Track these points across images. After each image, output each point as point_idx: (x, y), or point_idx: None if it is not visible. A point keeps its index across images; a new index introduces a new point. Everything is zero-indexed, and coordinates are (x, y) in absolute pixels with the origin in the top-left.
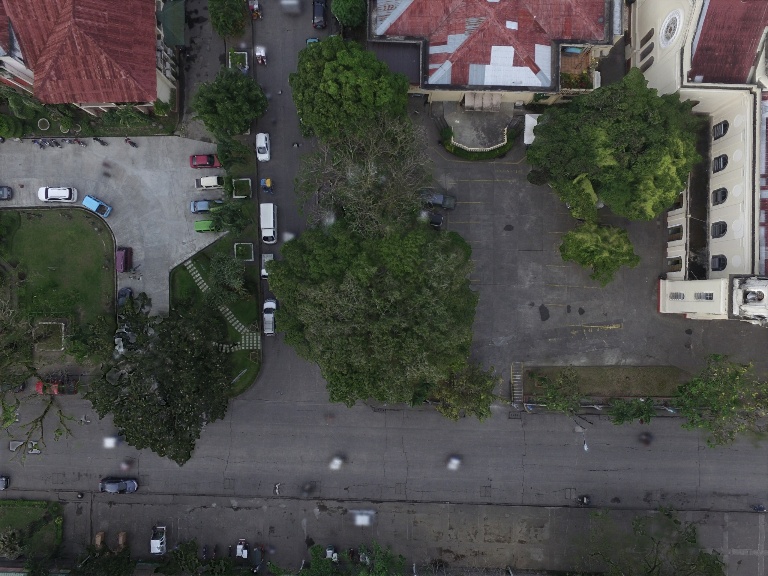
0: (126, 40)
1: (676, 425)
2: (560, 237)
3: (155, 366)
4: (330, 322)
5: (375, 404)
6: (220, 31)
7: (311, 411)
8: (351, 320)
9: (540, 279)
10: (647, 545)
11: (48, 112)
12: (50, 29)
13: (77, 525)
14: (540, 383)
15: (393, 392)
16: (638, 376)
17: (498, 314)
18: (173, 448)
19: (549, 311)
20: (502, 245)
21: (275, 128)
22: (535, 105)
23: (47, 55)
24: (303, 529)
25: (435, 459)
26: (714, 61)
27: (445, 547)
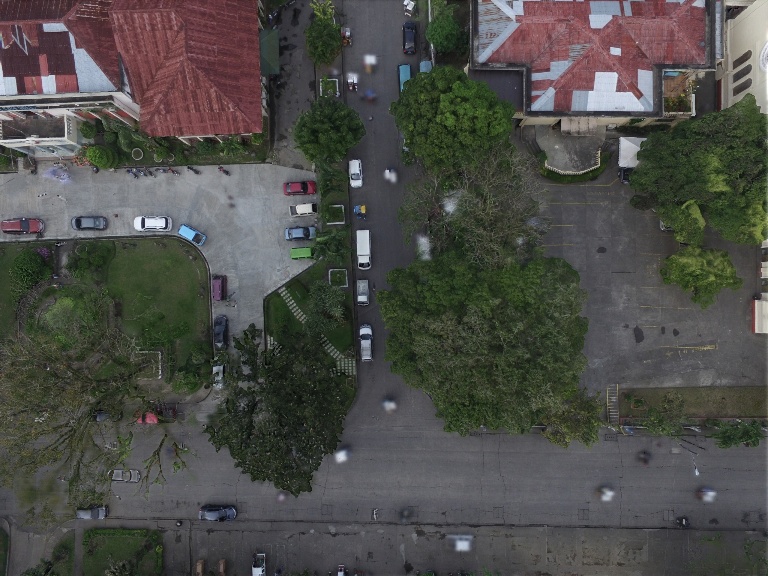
0: (234, 73)
1: None
2: (655, 259)
3: (279, 400)
4: (450, 353)
5: None
6: (317, 60)
7: (407, 436)
8: (475, 352)
9: (634, 301)
10: (746, 566)
11: (144, 142)
12: (159, 63)
13: (176, 553)
14: (637, 405)
15: (515, 422)
16: (734, 397)
17: (593, 336)
18: (297, 481)
19: (643, 333)
20: (595, 267)
21: (366, 154)
22: (627, 127)
23: (156, 89)
24: (401, 554)
25: (532, 482)
26: None
27: (544, 570)
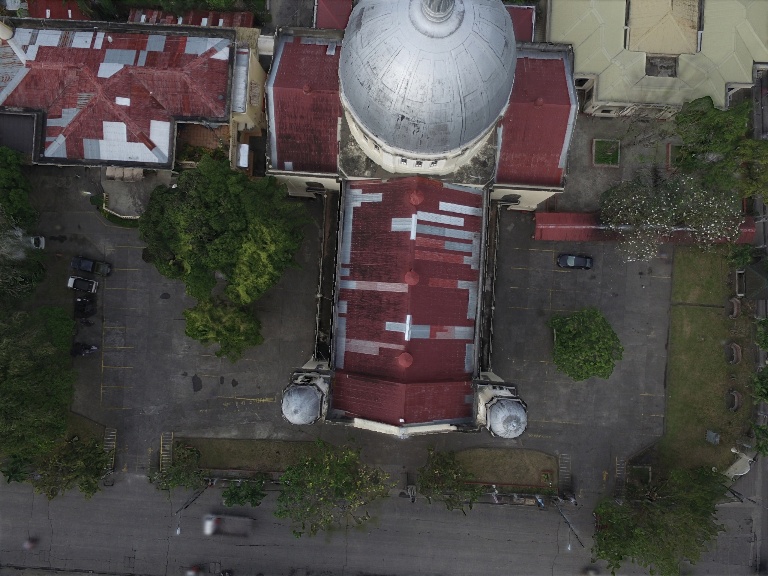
0: None
1: None
2: None
3: None
4: None
5: None
6: None
7: None
8: None
9: (194, 349)
10: None
11: None
12: None
13: None
14: None
15: None
16: (289, 451)
17: (150, 383)
18: None
19: (202, 382)
20: (158, 313)
21: None
22: None
23: None
24: None
25: (80, 527)
26: (298, 149)
27: None
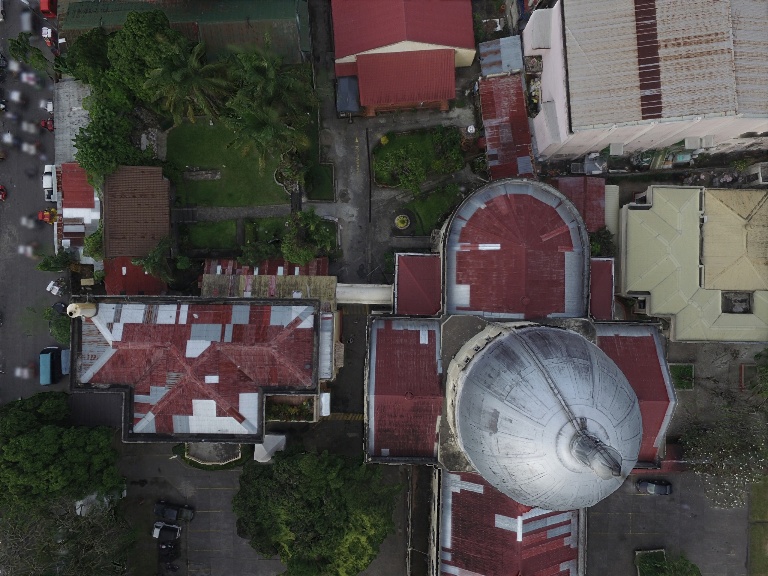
0: None
1: None
2: None
3: None
4: None
5: None
6: None
7: None
8: None
9: None
10: None
11: None
12: None
13: None
14: None
15: None
16: None
17: None
18: None
19: None
20: (242, 554)
21: None
22: None
23: None
24: None
25: None
26: (396, 439)
27: None
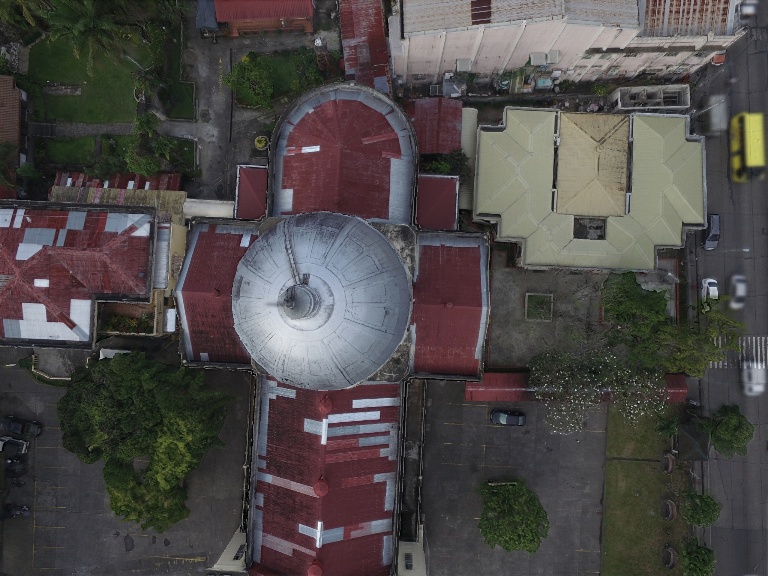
0: None
1: None
2: None
3: None
4: None
5: None
6: None
7: None
8: None
9: None
10: None
11: None
12: None
13: None
14: None
15: None
16: None
17: (82, 543)
18: None
19: (134, 541)
20: (89, 472)
21: None
22: None
23: None
24: None
25: None
26: (212, 342)
27: None
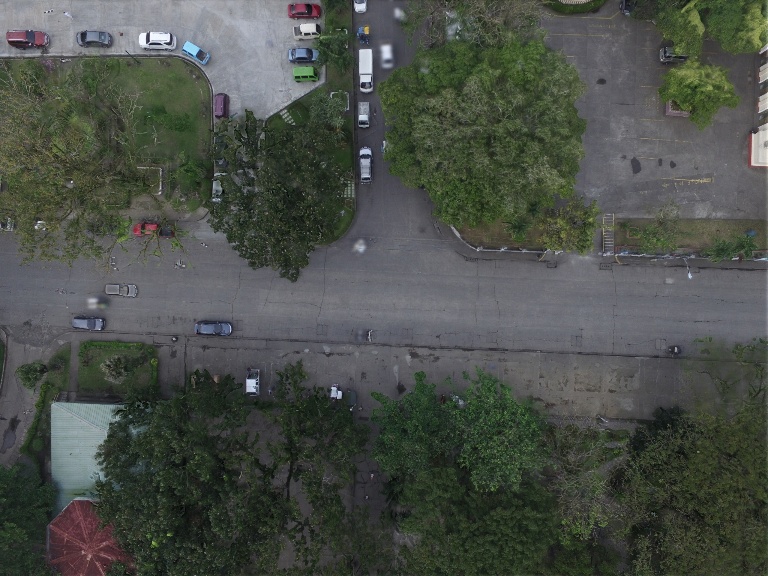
0: None
1: (766, 278)
2: None
3: (278, 168)
4: (449, 130)
5: (467, 253)
6: None
7: (404, 259)
8: (474, 122)
9: (632, 132)
10: (736, 396)
11: None
12: None
13: (171, 368)
14: (632, 234)
15: (511, 199)
16: (728, 229)
17: (590, 166)
18: (294, 250)
19: (641, 164)
20: (595, 98)
21: None
22: None
23: None
24: (395, 375)
25: (526, 308)
26: None
27: (536, 395)
